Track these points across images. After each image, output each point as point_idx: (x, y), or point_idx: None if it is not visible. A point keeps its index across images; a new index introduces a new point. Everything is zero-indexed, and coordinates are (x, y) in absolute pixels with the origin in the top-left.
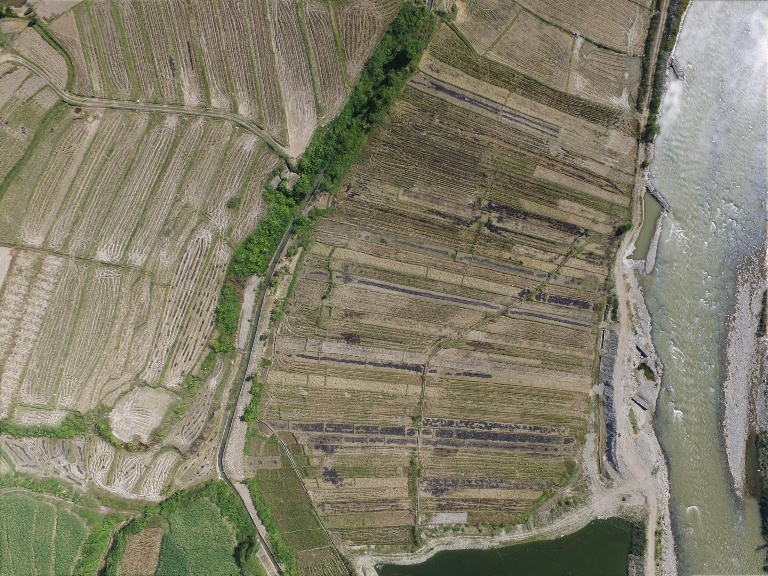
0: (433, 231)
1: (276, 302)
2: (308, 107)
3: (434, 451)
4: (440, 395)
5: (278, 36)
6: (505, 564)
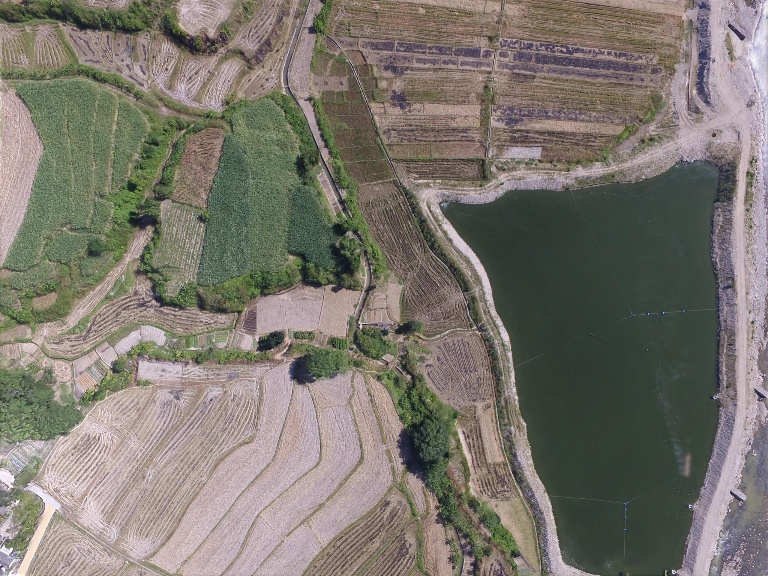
0: None
1: None
2: None
3: (510, 76)
4: (520, 13)
5: None
6: (579, 208)
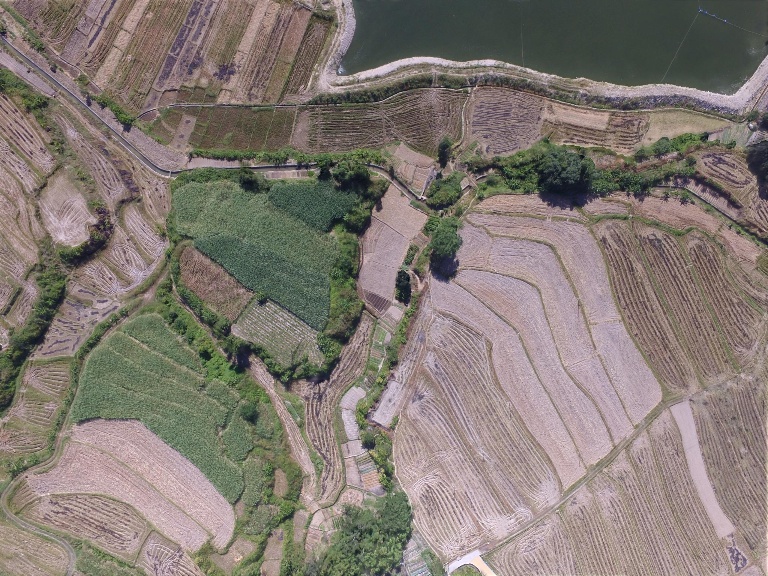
0: None
1: (24, 39)
2: None
3: None
4: None
5: None
6: None
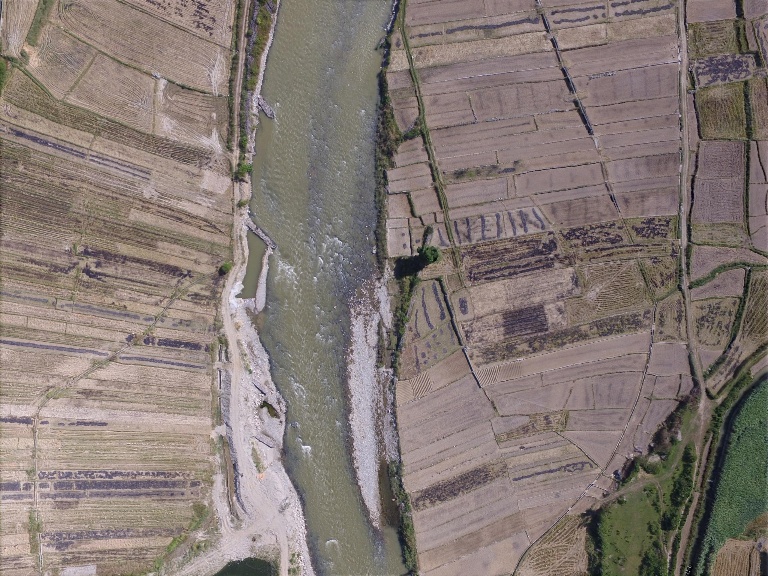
0: (29, 279)
1: None
2: None
3: (54, 504)
4: (54, 447)
5: None
6: None
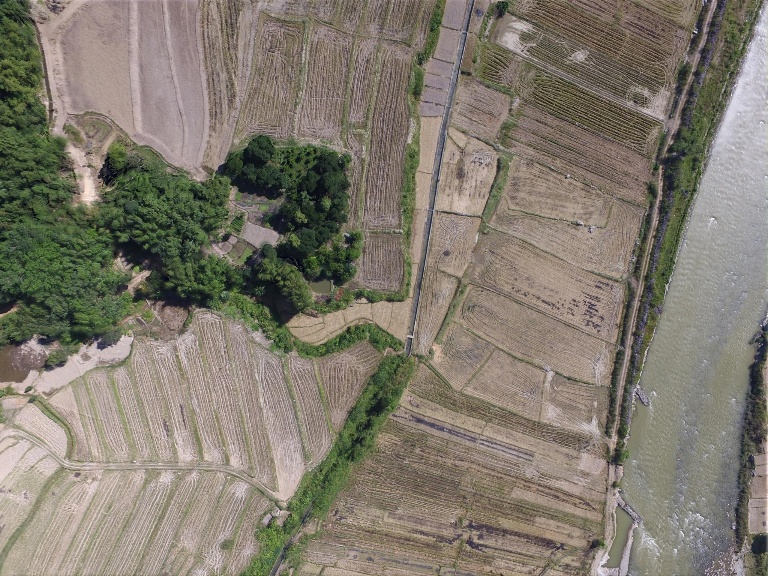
0: (417, 549)
1: None
2: (296, 454)
3: None
4: None
5: (266, 392)
6: None
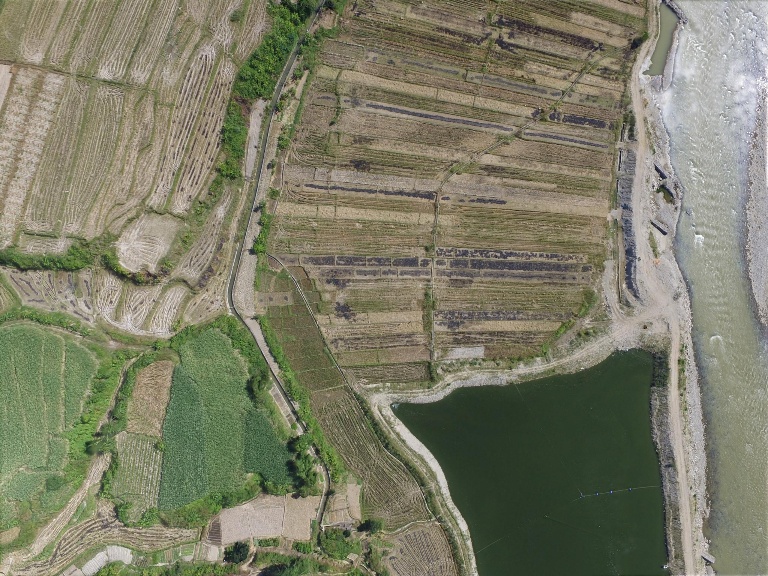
0: (442, 50)
1: (283, 128)
2: None
3: (449, 282)
4: (453, 223)
5: None
6: (524, 400)
